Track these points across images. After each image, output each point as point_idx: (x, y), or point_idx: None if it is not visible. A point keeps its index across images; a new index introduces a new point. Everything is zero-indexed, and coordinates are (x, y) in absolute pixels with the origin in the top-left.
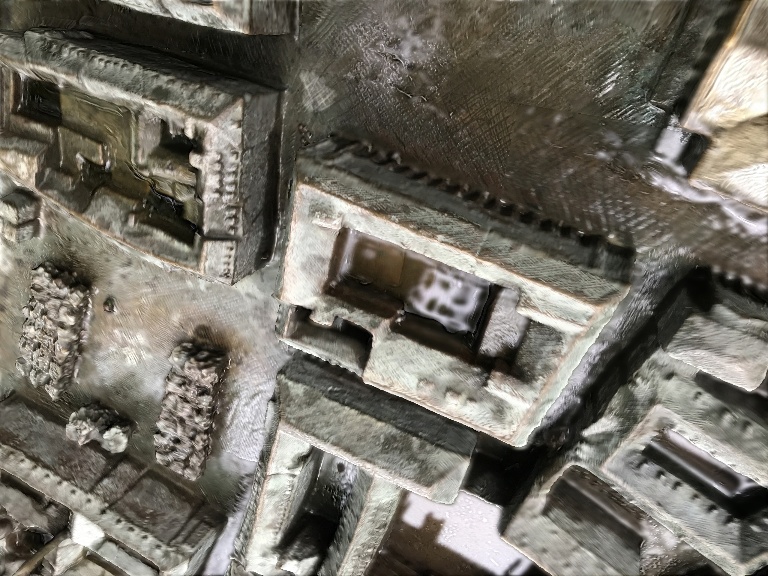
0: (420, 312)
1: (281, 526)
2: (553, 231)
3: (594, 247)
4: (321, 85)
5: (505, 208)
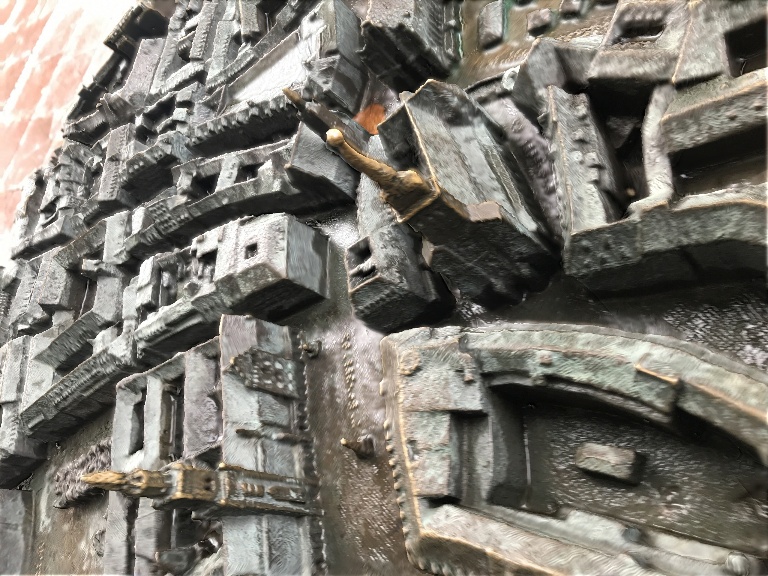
0: None
1: None
2: None
3: None
4: None
5: None
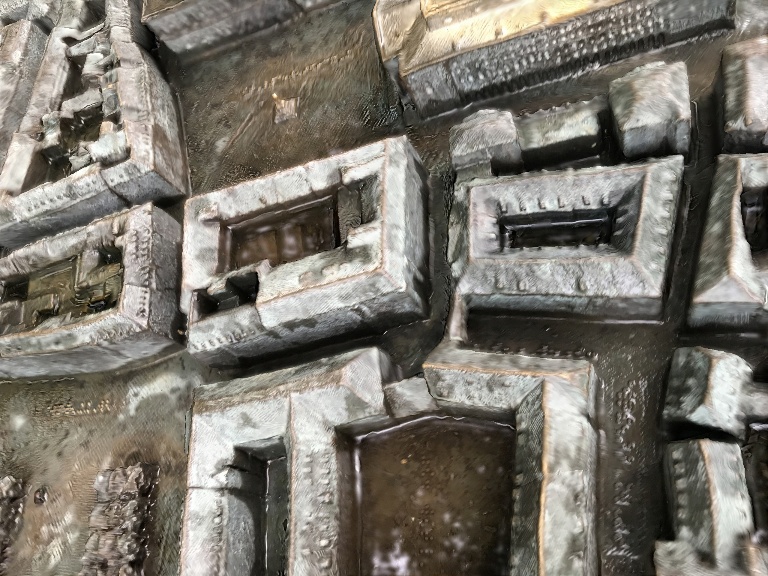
0: None
1: None
2: None
3: None
4: None
5: None
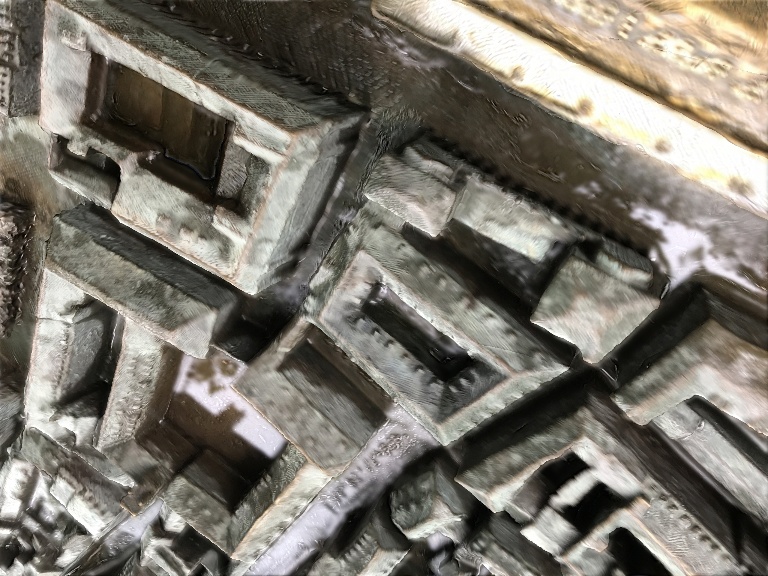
0: (179, 158)
1: (60, 380)
2: (291, 79)
3: (323, 96)
4: None
5: (259, 59)
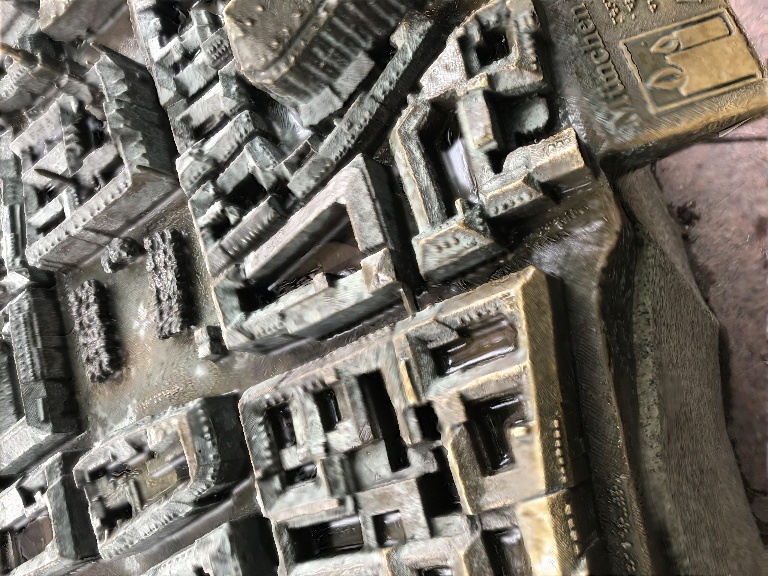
0: None
1: None
2: None
3: None
4: (132, 568)
5: None
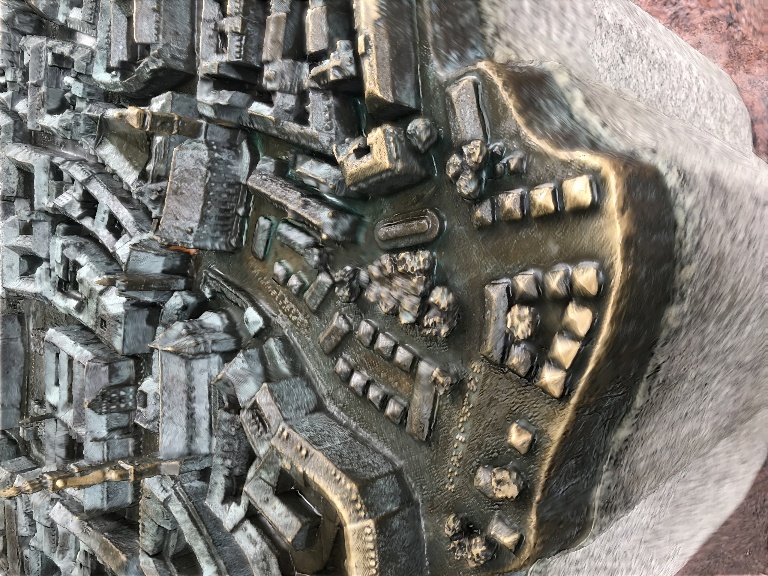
0: None
1: None
2: None
3: None
4: (4, 303)
5: None
